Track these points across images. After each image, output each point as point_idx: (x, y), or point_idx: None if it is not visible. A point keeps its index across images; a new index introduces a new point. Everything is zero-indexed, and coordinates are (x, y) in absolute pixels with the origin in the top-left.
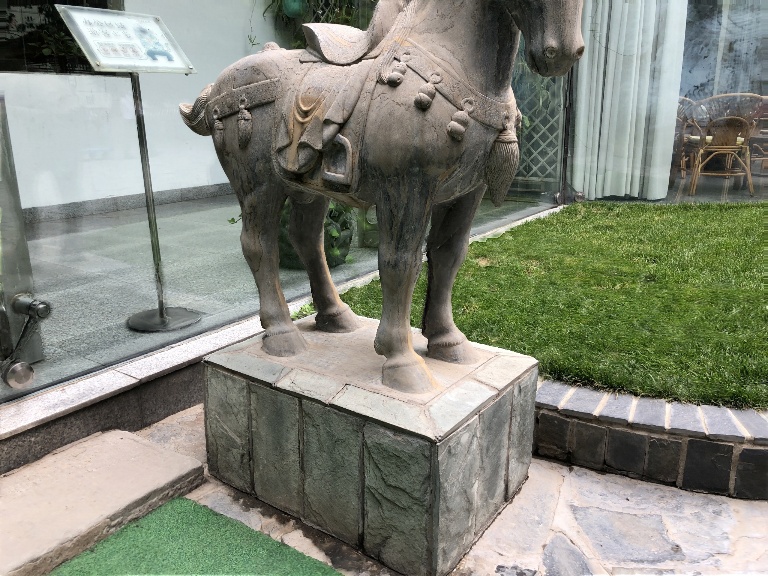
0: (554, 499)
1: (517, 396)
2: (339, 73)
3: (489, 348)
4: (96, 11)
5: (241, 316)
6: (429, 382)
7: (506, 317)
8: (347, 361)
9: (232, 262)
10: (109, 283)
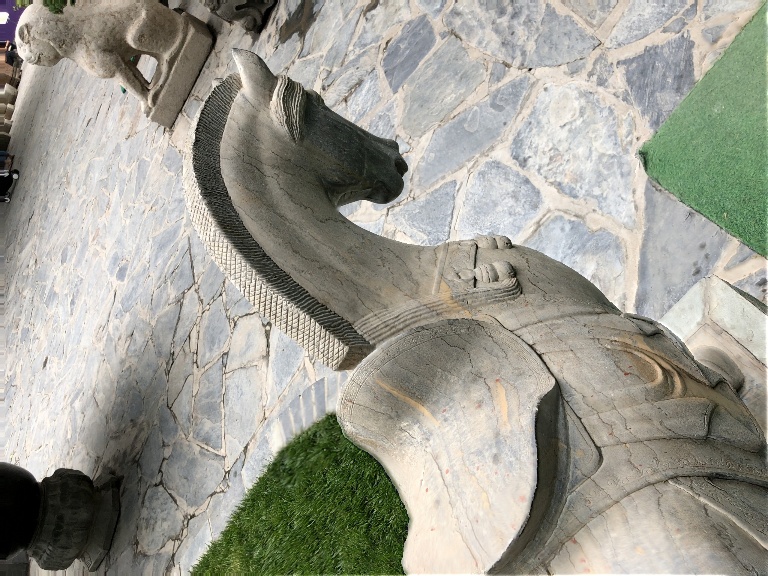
0: None
1: None
2: (558, 346)
3: None
4: None
5: None
6: None
7: None
8: None
9: None
10: None
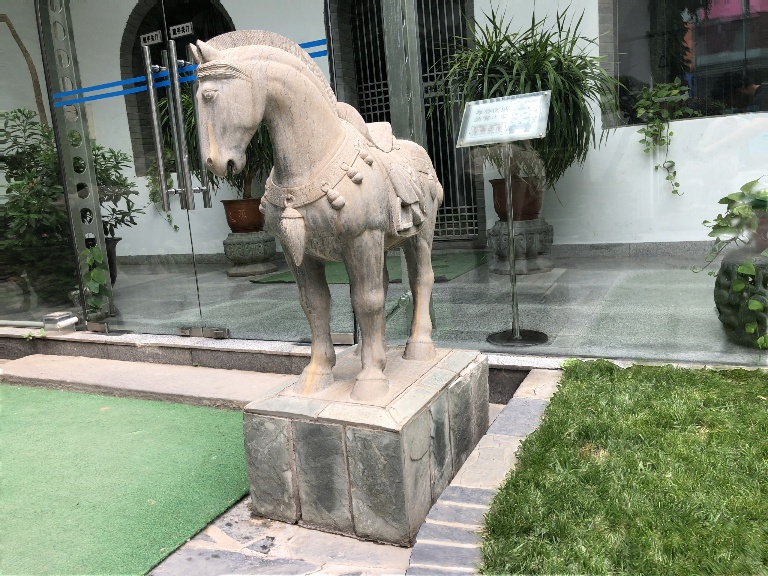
0: (373, 564)
1: (353, 441)
2: None
3: (404, 405)
4: (493, 103)
5: (552, 353)
6: (303, 388)
7: (676, 447)
8: (346, 367)
9: (706, 318)
10: (584, 309)
